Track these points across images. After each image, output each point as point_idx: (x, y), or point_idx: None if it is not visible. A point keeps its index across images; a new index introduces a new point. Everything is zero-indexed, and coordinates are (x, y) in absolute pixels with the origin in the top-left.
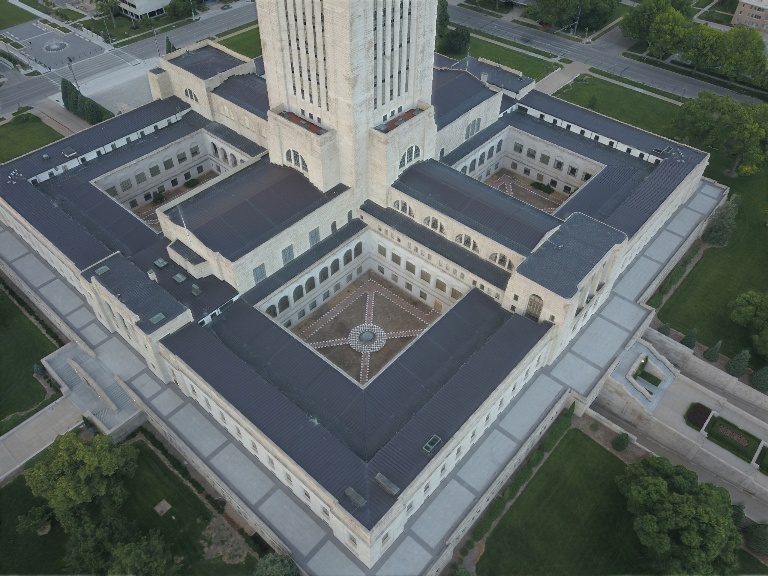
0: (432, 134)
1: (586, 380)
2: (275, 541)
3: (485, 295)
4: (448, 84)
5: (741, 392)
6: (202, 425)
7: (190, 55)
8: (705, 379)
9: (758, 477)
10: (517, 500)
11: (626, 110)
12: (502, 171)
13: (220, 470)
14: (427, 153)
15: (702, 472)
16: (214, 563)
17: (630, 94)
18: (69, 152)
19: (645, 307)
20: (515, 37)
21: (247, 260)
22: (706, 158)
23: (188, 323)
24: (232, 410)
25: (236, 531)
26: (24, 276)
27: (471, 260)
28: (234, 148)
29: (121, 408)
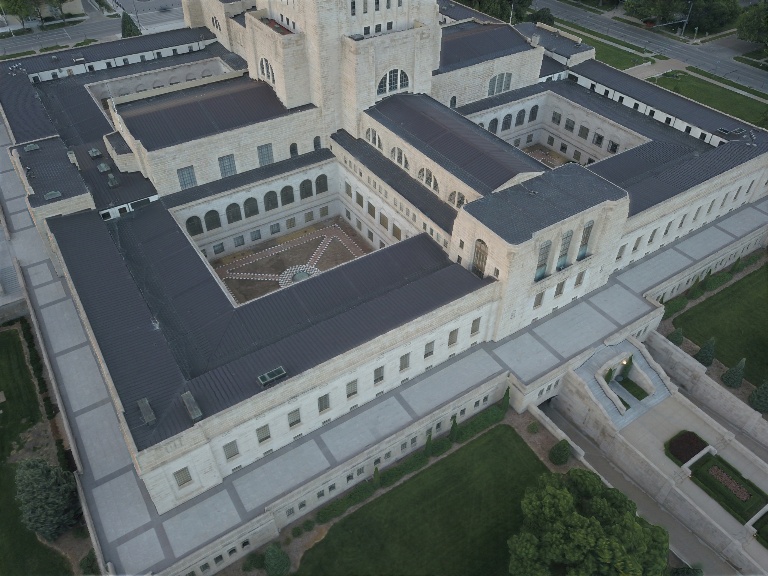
0: (425, 61)
1: (536, 367)
2: (73, 456)
3: (434, 242)
4: (482, 33)
5: (764, 435)
6: (70, 322)
7: None
8: (719, 410)
9: (751, 546)
10: (394, 489)
11: None
12: (536, 146)
13: (61, 369)
14: (419, 85)
15: (672, 523)
16: (13, 468)
17: (729, 95)
18: (77, 57)
19: (652, 302)
20: (608, 30)
21: (168, 154)
22: None
23: (87, 209)
24: (74, 295)
25: (54, 441)
26: None
27: (428, 200)
28: None
29: (9, 293)
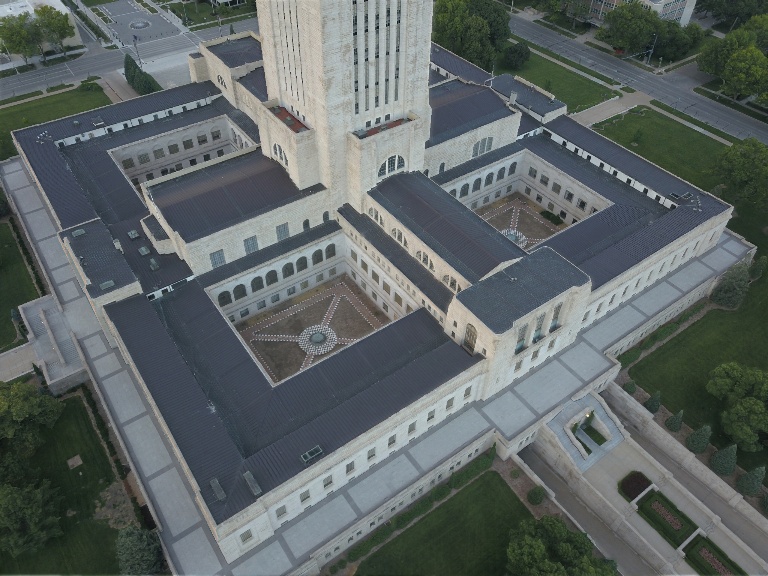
0: (419, 146)
1: (517, 423)
2: (152, 516)
3: (431, 316)
4: (466, 99)
5: (697, 470)
6: (129, 393)
7: (230, 44)
8: (663, 449)
9: (680, 566)
10: (406, 531)
11: (675, 149)
12: (515, 195)
13: (129, 438)
14: (413, 165)
15: (623, 547)
16: (100, 524)
17: (687, 132)
18: (97, 121)
19: (611, 359)
20: (581, 59)
21: (203, 244)
22: (727, 210)
23: (136, 294)
24: (141, 383)
25: (130, 499)
26: (31, 228)
27: (426, 279)
28: (247, 136)
29: (69, 363)
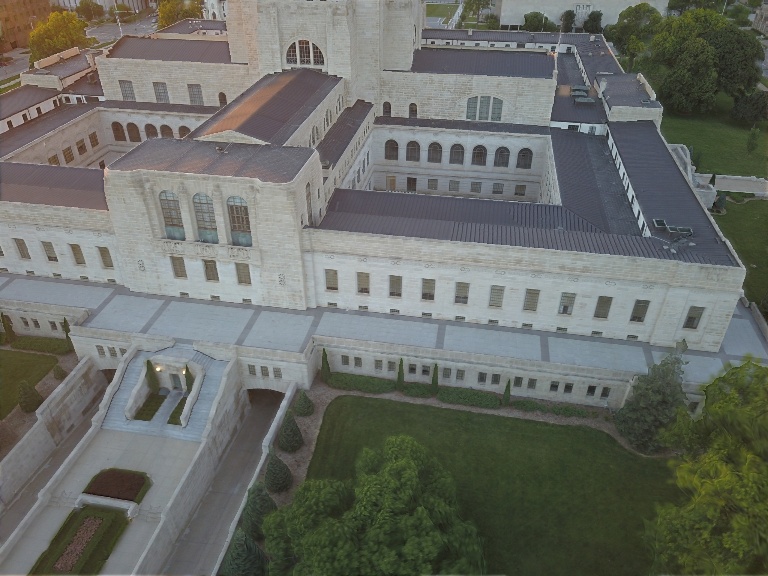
0: (341, 41)
1: (115, 324)
2: None
3: None
4: (509, 55)
5: None
6: None
7: None
8: None
9: None
10: None
11: None
12: None
13: None
14: (334, 66)
15: None
16: None
17: None
18: None
19: None
20: None
21: (111, 64)
22: (722, 268)
23: (55, 89)
24: None
25: None
26: None
27: None
28: None
29: None
